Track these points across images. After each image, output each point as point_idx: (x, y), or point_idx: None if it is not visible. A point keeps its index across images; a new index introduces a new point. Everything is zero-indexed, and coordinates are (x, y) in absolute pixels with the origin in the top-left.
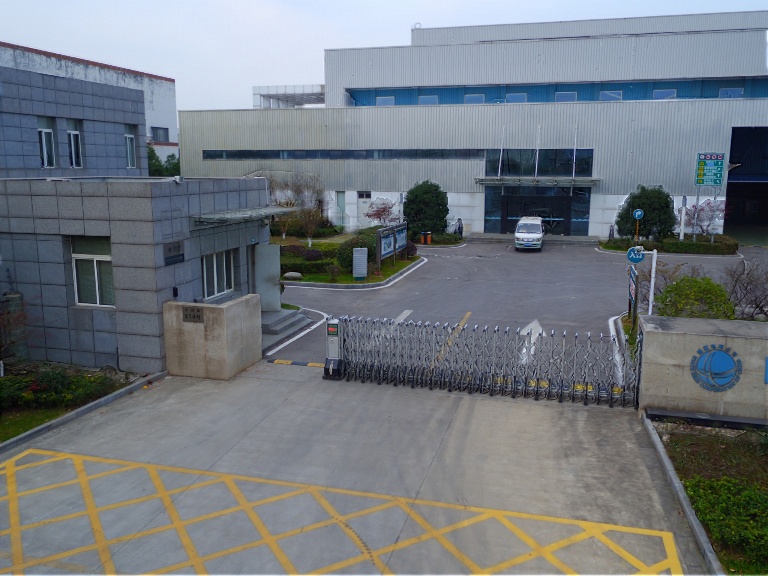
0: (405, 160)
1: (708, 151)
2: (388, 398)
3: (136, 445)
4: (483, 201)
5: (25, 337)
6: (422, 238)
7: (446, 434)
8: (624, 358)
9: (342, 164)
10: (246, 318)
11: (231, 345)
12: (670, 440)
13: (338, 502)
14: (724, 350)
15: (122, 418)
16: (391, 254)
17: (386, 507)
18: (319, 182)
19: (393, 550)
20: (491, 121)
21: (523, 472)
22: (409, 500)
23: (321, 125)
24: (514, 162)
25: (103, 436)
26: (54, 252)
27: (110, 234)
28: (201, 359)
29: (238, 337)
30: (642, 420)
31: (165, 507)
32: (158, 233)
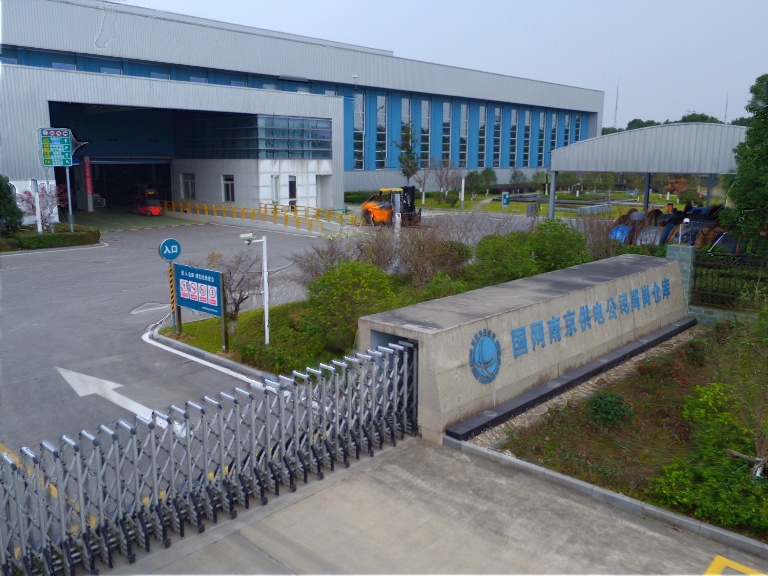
0: None
1: (26, 127)
2: None
3: None
4: None
5: None
6: None
7: None
8: (391, 377)
9: None
10: None
11: None
12: (516, 454)
13: None
14: (487, 334)
15: None
16: None
17: None
18: None
19: None
20: None
21: None
22: None
23: None
24: None
25: None
26: None
27: None
28: None
29: None
30: (452, 445)
31: None
32: None
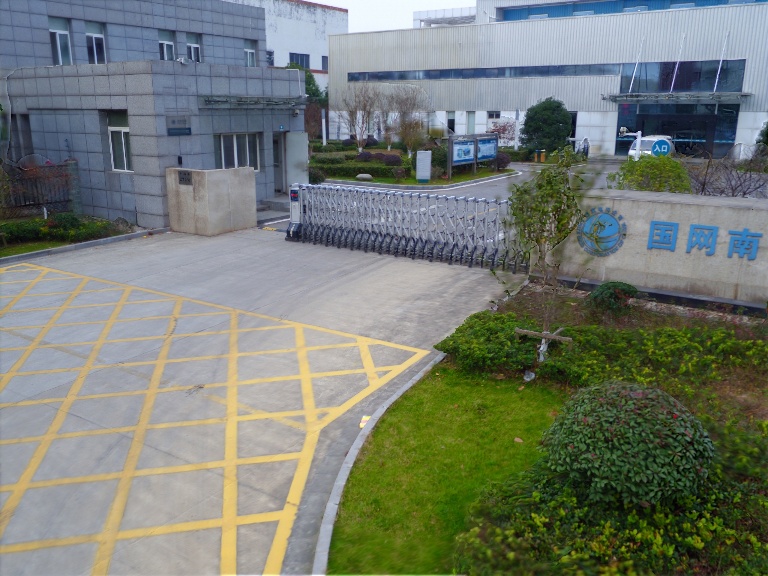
0: (536, 77)
1: None
2: (320, 254)
3: (94, 266)
4: (615, 120)
5: (80, 197)
6: (535, 156)
7: (335, 279)
8: None
9: (474, 83)
10: (235, 186)
11: (214, 206)
12: None
13: (188, 307)
14: (610, 213)
15: (105, 252)
16: (469, 162)
17: (220, 314)
18: (421, 94)
19: (189, 336)
20: (630, 32)
21: (362, 305)
22: (243, 312)
23: (455, 43)
24: (653, 77)
25: (79, 260)
26: (94, 125)
27: (127, 107)
28: (192, 217)
29: (224, 201)
30: None
31: (67, 298)
32: (160, 106)
